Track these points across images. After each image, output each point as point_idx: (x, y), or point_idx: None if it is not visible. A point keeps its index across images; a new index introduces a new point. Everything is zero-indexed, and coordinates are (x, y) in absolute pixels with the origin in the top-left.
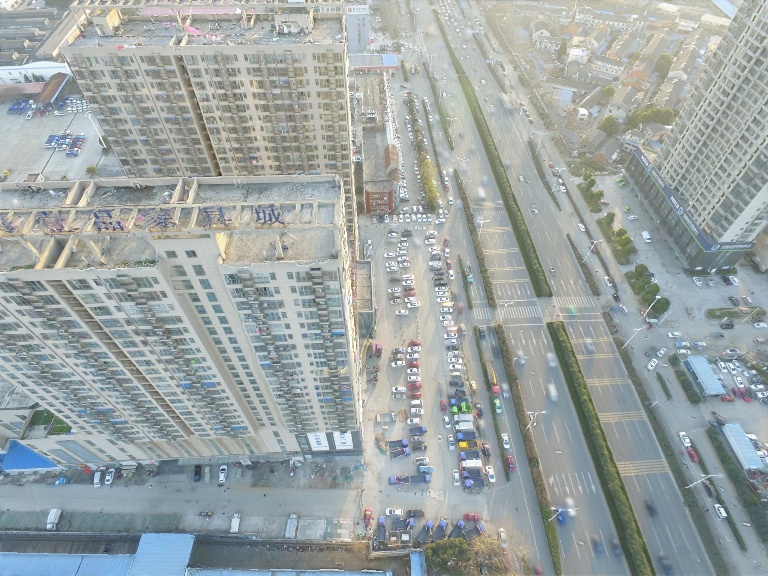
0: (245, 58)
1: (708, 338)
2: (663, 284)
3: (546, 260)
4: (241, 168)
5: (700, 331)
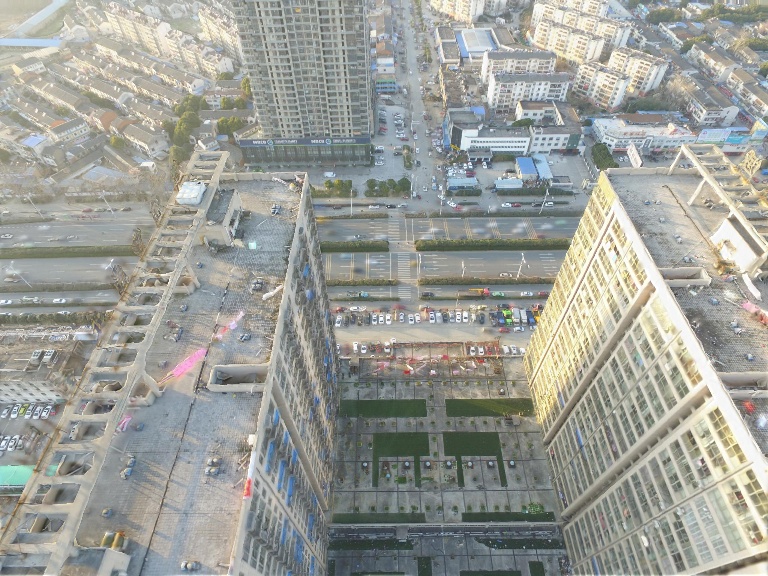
0: (291, 288)
1: (427, 175)
2: (379, 180)
3: (345, 238)
4: (314, 435)
5: (422, 176)
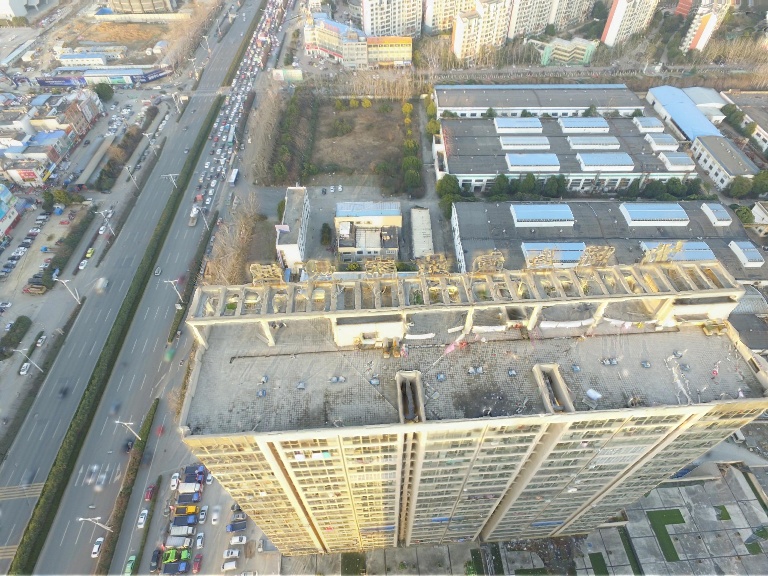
0: None
1: None
2: None
3: None
4: None
5: None
